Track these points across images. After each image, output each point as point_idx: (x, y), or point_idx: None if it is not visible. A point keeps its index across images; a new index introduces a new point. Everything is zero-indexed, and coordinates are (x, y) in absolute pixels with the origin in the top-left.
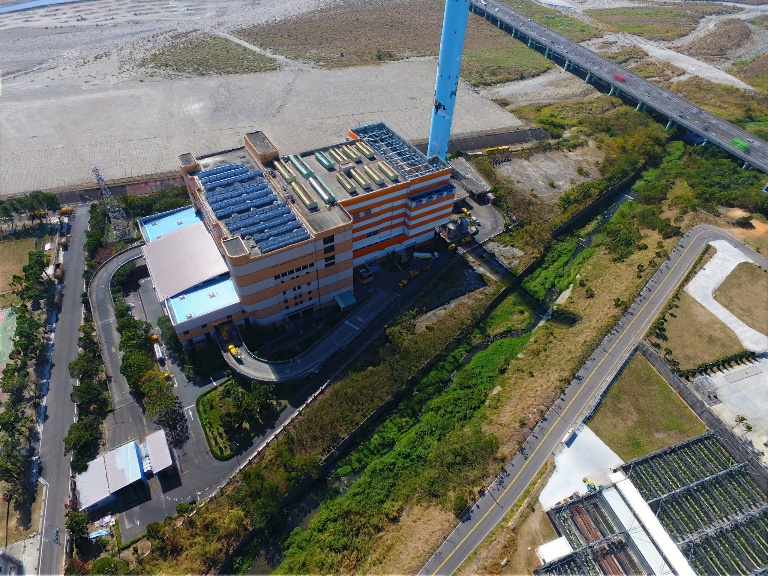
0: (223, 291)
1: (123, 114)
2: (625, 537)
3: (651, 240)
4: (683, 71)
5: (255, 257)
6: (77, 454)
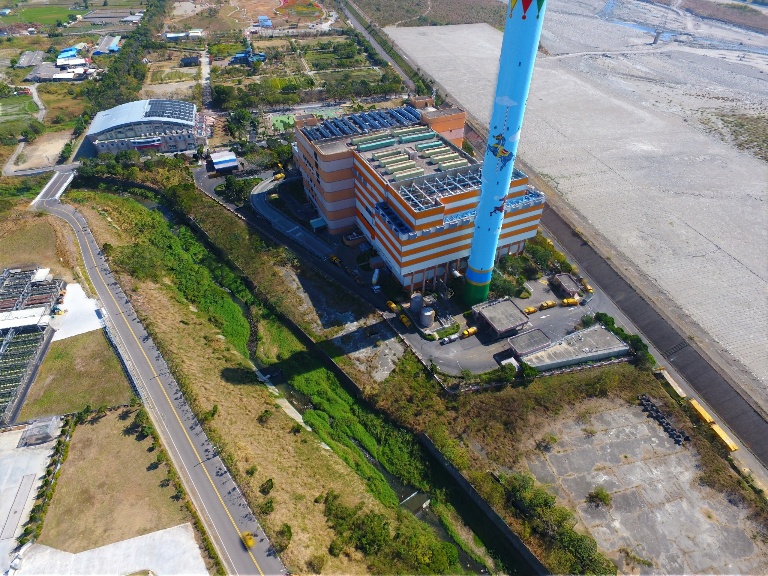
0: None
1: (601, 120)
2: None
3: None
4: None
5: (297, 127)
6: (238, 147)
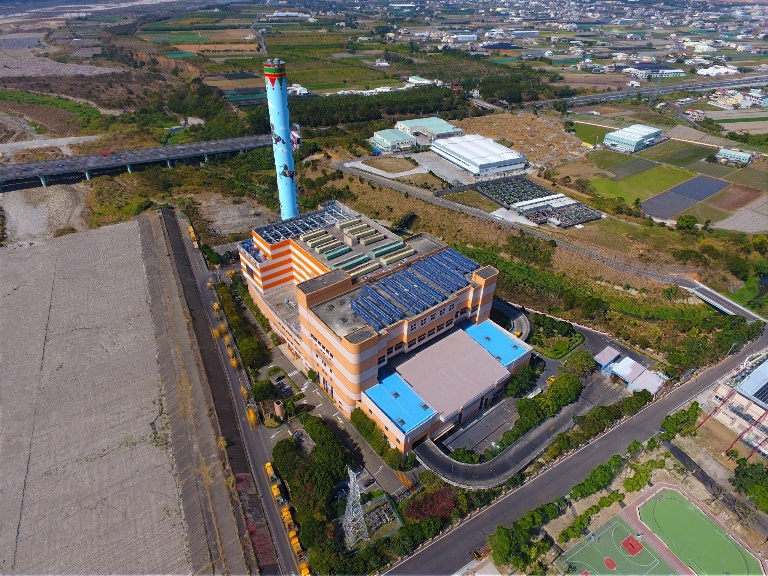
0: (480, 333)
1: None
2: (536, 209)
3: (339, 184)
4: (54, 147)
5: None
6: None
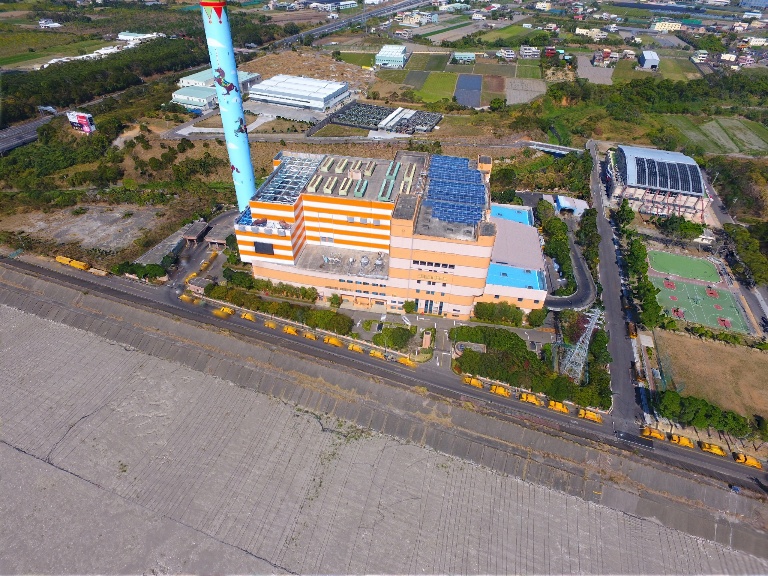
0: (491, 213)
1: None
2: None
3: (195, 154)
4: None
5: None
6: None
